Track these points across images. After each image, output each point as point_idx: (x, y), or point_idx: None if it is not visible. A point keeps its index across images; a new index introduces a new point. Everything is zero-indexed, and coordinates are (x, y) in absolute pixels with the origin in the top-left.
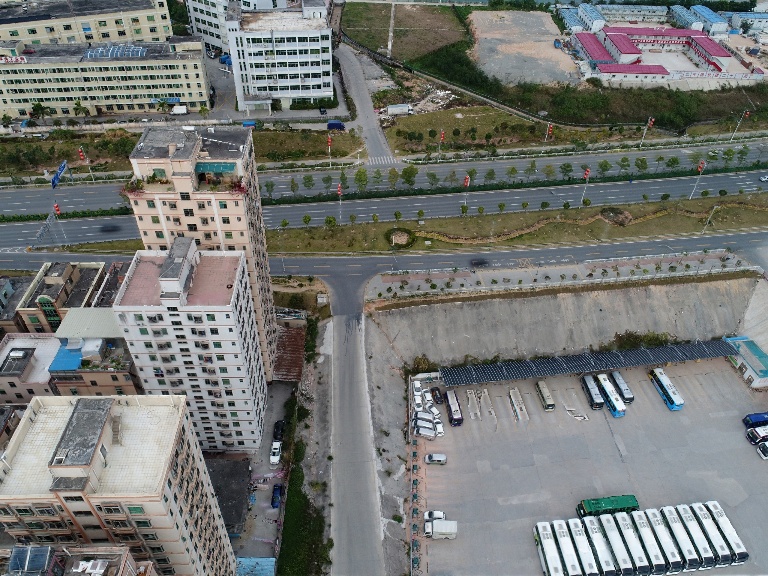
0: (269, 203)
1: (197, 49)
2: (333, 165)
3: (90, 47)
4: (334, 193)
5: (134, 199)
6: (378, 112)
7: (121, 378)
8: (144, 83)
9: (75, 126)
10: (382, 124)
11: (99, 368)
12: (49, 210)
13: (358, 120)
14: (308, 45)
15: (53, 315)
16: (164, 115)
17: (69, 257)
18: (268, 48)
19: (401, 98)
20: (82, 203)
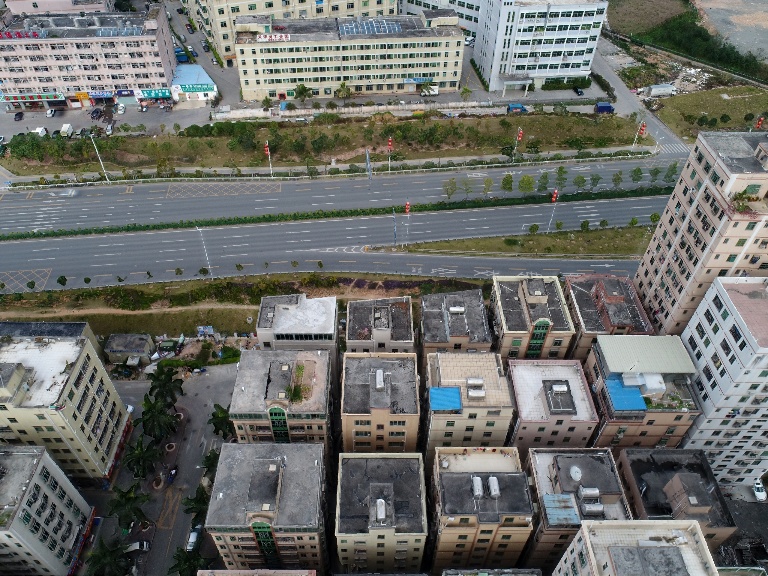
0: (589, 198)
1: (452, 24)
2: (630, 154)
3: (338, 22)
4: (657, 187)
5: (737, 221)
6: (636, 93)
7: (685, 418)
8: (401, 62)
9: (334, 109)
10: (649, 106)
11: None
12: (359, 204)
13: (620, 102)
14: (581, 20)
15: (539, 338)
16: (414, 96)
17: (412, 258)
18: (540, 23)
19: (654, 77)
20: (389, 196)
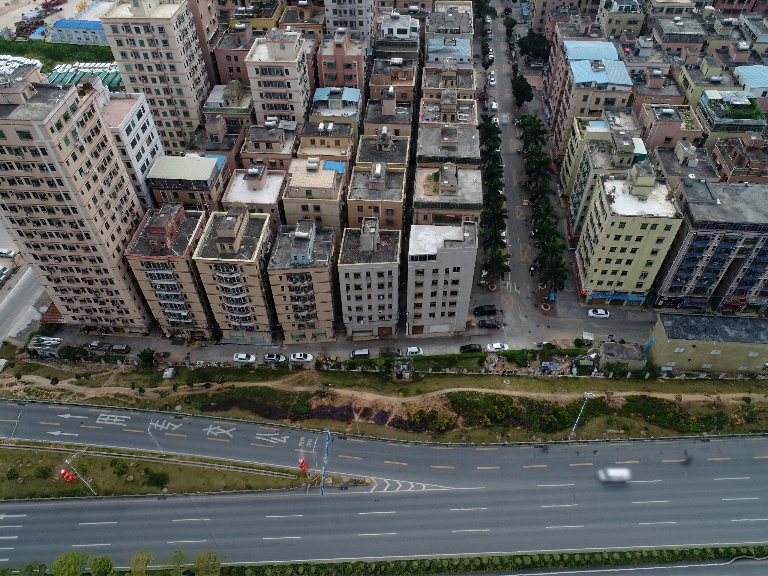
0: None
1: None
2: None
3: None
4: None
5: None
6: None
7: None
8: None
9: None
10: None
11: (189, 152)
12: None
13: None
14: None
15: None
16: None
17: (307, 463)
18: None
19: None
20: None
